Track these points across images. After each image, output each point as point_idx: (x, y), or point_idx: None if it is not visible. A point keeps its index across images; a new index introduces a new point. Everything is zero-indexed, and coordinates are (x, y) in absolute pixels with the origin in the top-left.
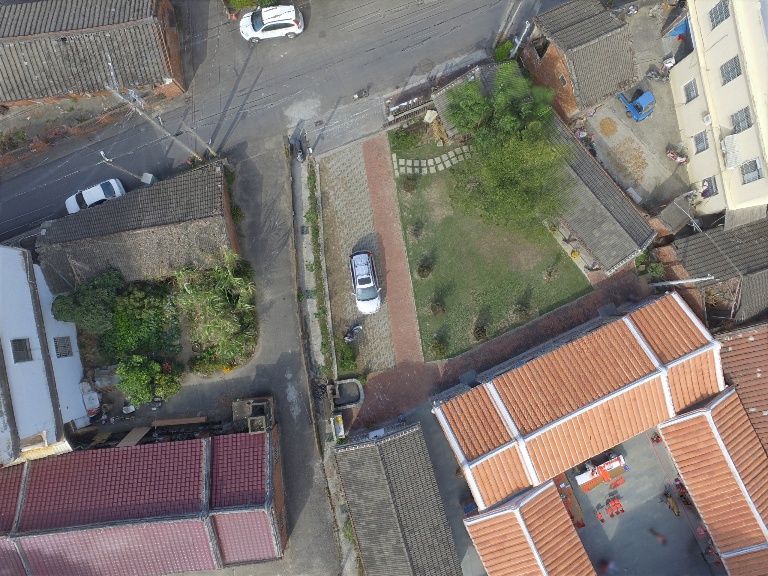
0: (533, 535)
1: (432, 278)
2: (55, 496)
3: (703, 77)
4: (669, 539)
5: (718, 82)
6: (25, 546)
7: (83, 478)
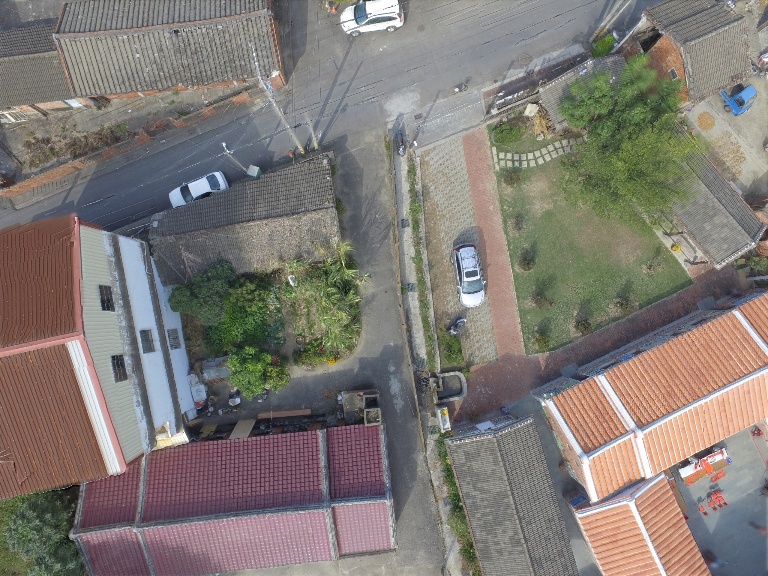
0: (647, 527)
1: (533, 271)
2: (175, 487)
3: None
4: None
5: None
6: (148, 537)
7: (202, 469)
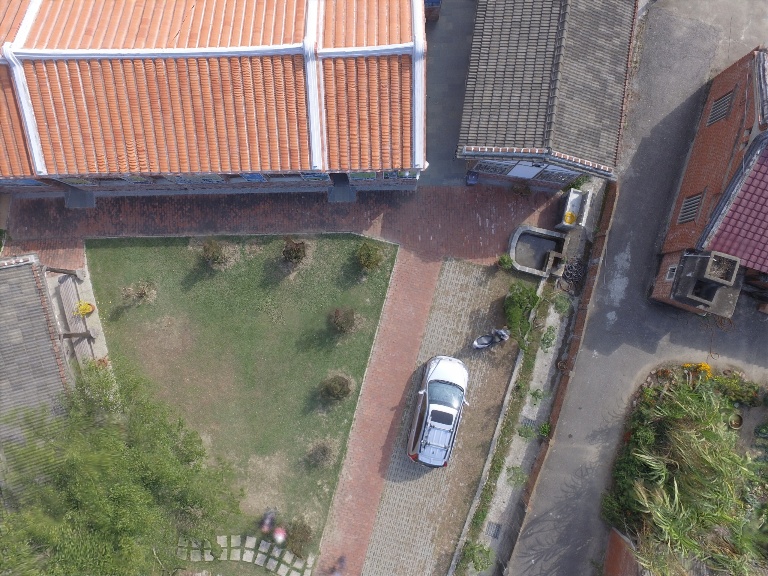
0: None
1: (330, 369)
2: None
3: None
4: None
5: None
6: None
7: None
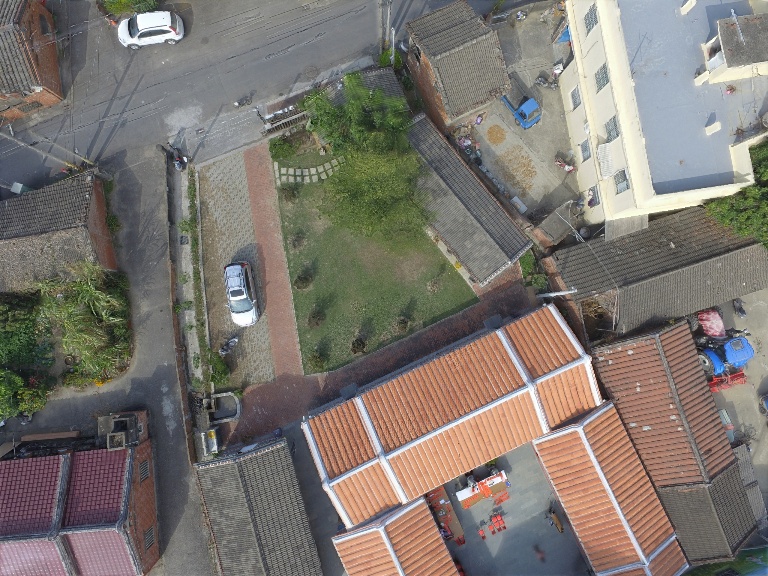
0: (399, 554)
1: (313, 289)
2: None
3: (581, 84)
4: (554, 556)
5: (593, 90)
6: None
7: None
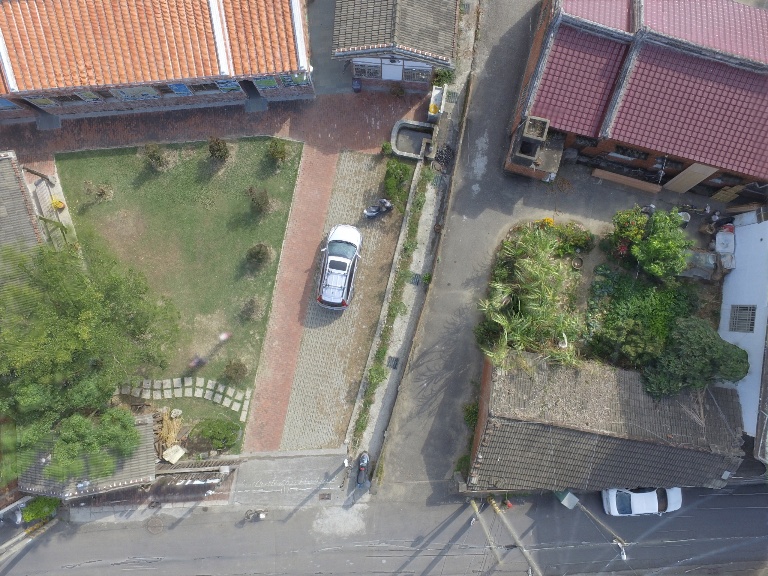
0: None
1: (254, 243)
2: None
3: None
4: None
5: None
6: None
7: None
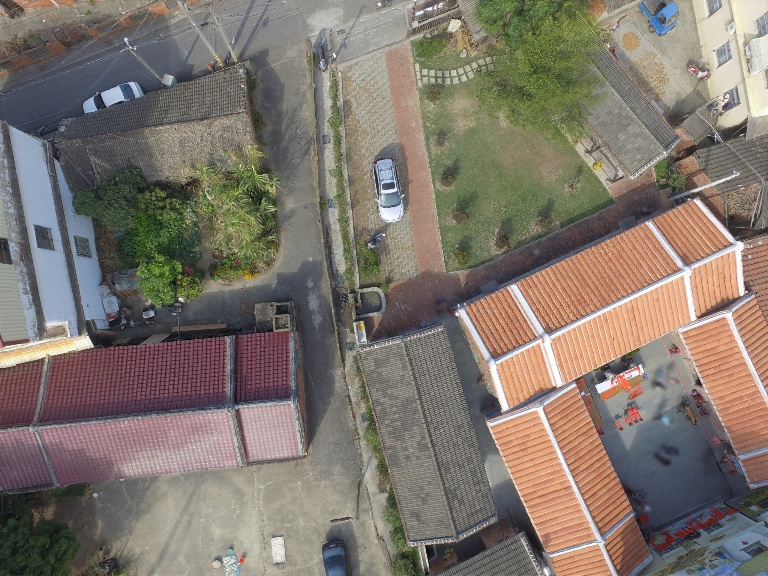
0: (556, 434)
1: (454, 189)
2: (77, 390)
3: None
4: (686, 449)
5: None
6: (47, 437)
7: (105, 373)
